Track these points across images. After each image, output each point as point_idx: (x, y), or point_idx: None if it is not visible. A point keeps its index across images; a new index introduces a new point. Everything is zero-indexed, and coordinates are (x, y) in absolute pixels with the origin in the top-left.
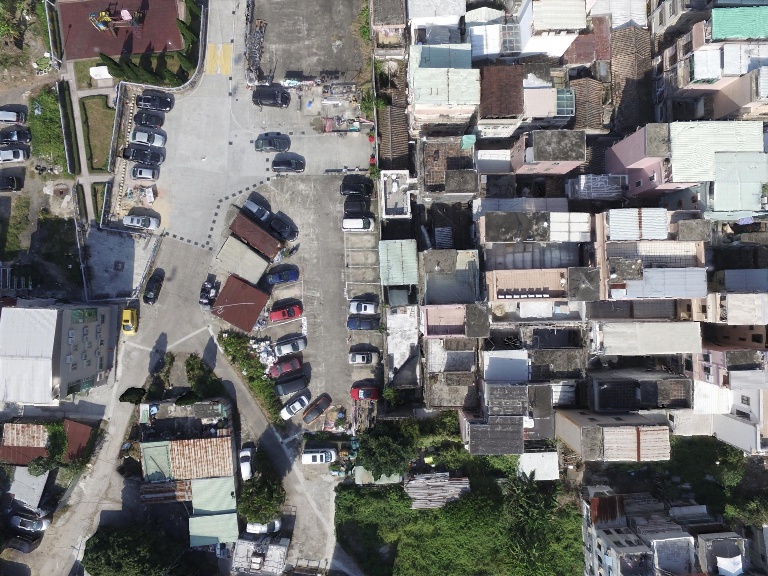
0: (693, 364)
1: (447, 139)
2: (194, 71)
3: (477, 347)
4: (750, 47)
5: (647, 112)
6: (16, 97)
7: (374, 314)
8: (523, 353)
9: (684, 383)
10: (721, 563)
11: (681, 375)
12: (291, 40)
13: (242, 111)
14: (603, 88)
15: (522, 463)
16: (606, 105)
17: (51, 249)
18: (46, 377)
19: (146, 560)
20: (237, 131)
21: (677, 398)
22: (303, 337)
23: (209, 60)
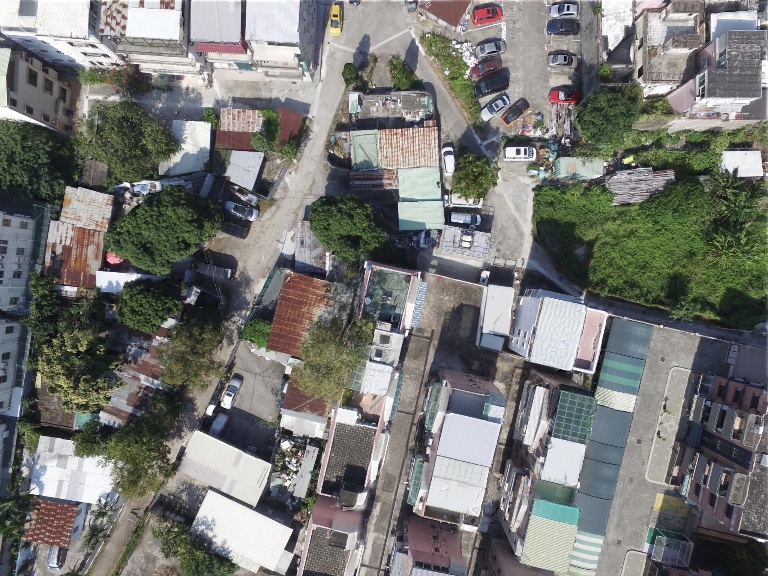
0: None
1: None
2: None
3: (696, 22)
4: None
5: None
6: None
7: (574, 19)
8: (753, 13)
9: None
10: None
11: None
12: None
13: None
14: None
15: (725, 160)
16: None
17: None
18: (293, 15)
19: (371, 220)
20: None
21: None
22: None
23: None
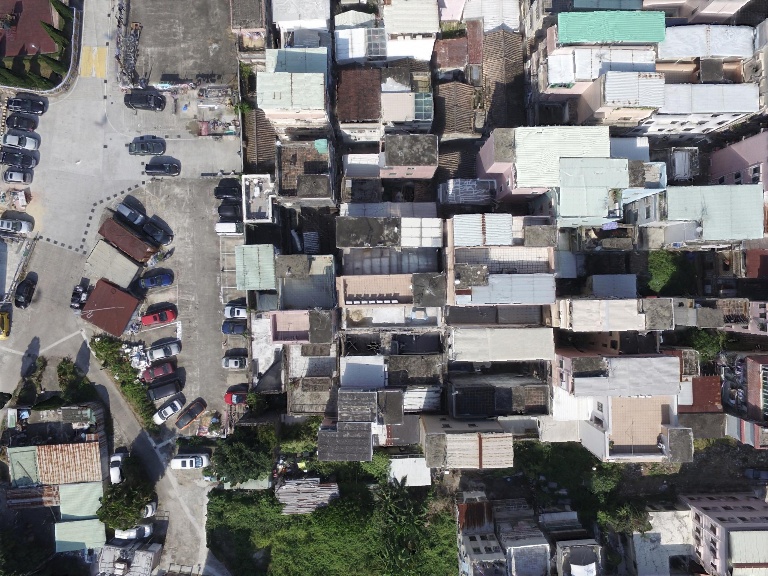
0: (552, 370)
1: (302, 143)
2: (66, 74)
3: (339, 352)
4: (601, 52)
5: (518, 116)
6: None
7: None
8: (379, 359)
9: (544, 389)
10: (575, 571)
11: (544, 381)
12: (167, 43)
13: (117, 114)
14: (474, 92)
15: (394, 469)
16: (477, 109)
17: None
18: None
19: (1, 566)
20: (112, 134)
21: (537, 404)
22: (177, 341)
23: (84, 63)
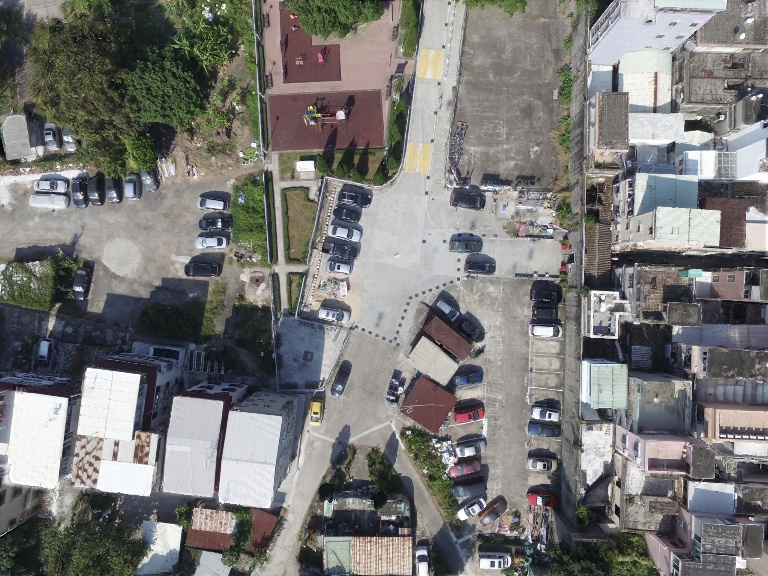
0: None
1: (669, 269)
2: (397, 171)
3: None
4: None
5: None
6: (221, 184)
7: (555, 421)
8: (730, 487)
9: None
10: None
11: None
12: (490, 143)
13: (437, 210)
14: None
15: None
16: None
17: (244, 335)
18: (268, 483)
19: None
20: (431, 230)
21: None
22: (483, 438)
23: (409, 158)
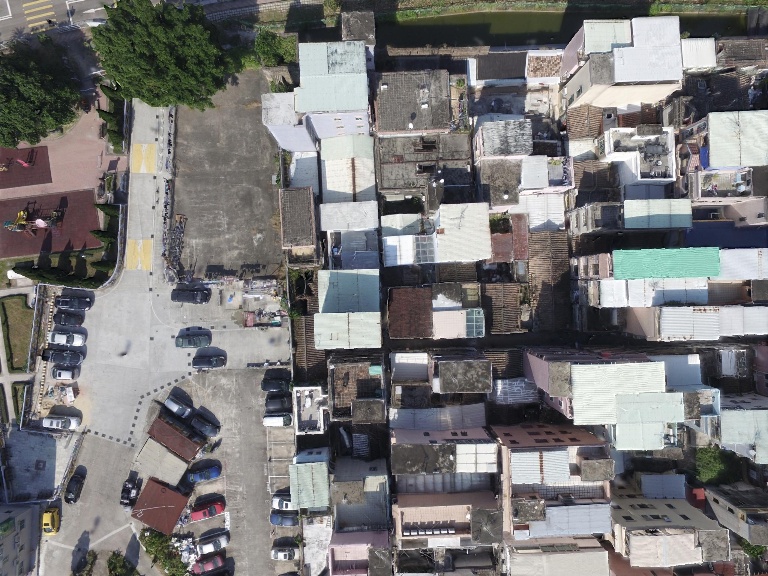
0: None
1: (355, 365)
2: (112, 272)
3: None
4: (654, 280)
5: (564, 314)
6: None
7: None
8: None
9: None
10: None
11: None
12: (211, 234)
13: (163, 306)
14: (520, 289)
15: None
16: (524, 306)
17: None
18: None
19: None
20: (158, 326)
21: None
22: (226, 532)
23: (129, 256)
